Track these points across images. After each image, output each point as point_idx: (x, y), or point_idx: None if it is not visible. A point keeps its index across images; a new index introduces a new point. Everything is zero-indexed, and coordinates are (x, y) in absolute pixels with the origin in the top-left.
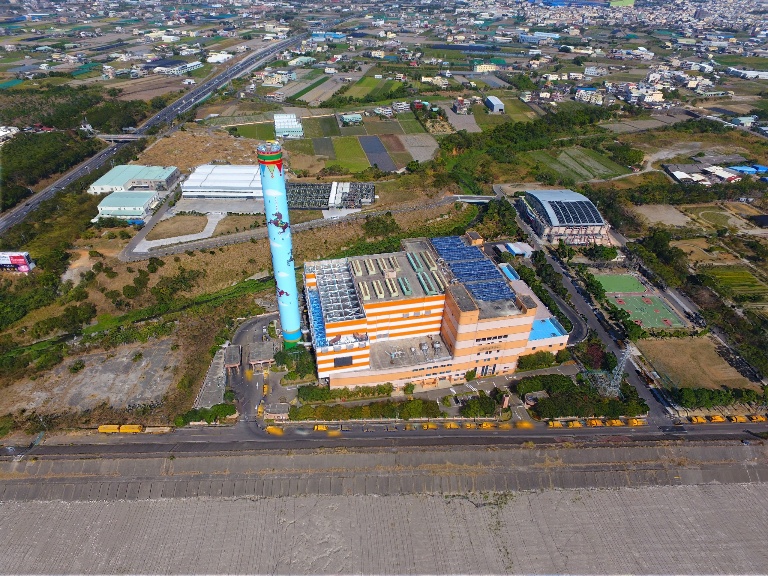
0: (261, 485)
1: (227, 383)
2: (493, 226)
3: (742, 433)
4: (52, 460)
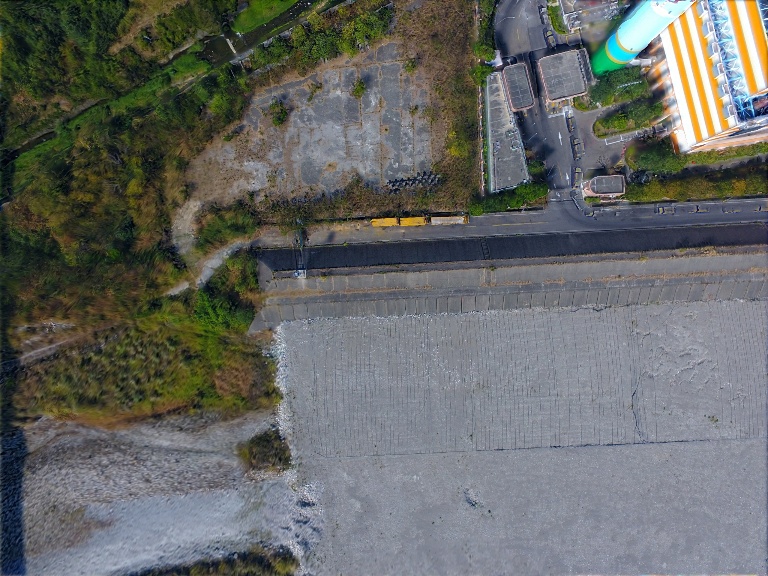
0: (606, 294)
1: (523, 142)
2: None
3: None
4: (345, 276)
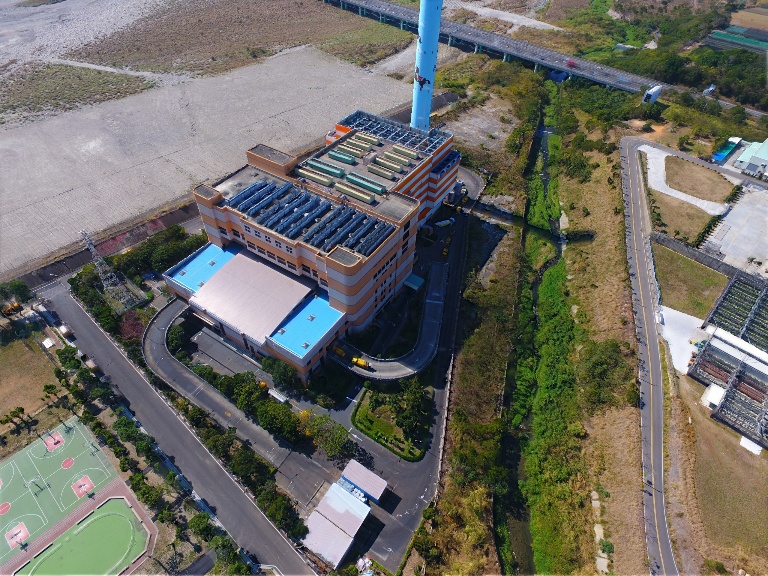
0: None
1: None
2: (454, 572)
3: None
4: None
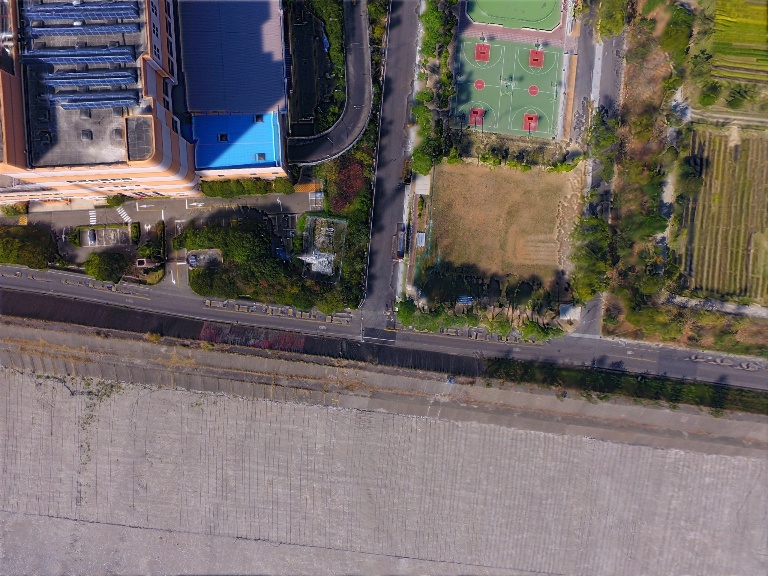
0: None
1: None
2: None
3: (469, 356)
4: None
